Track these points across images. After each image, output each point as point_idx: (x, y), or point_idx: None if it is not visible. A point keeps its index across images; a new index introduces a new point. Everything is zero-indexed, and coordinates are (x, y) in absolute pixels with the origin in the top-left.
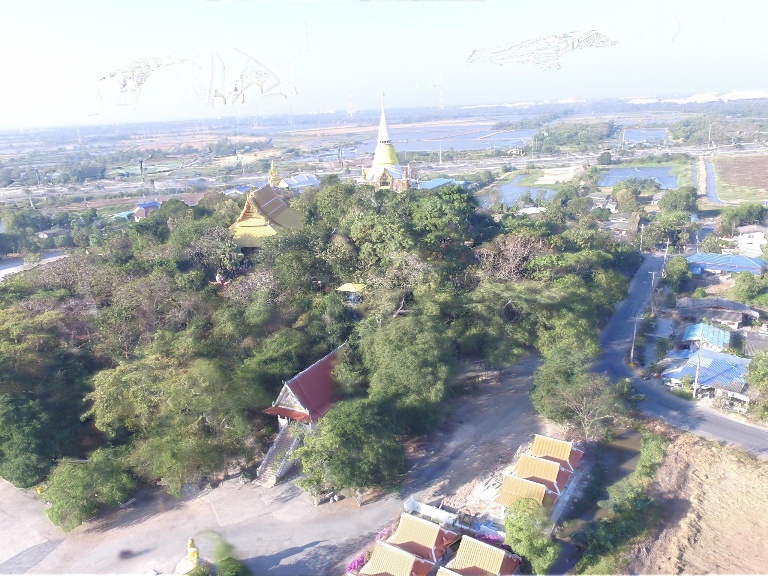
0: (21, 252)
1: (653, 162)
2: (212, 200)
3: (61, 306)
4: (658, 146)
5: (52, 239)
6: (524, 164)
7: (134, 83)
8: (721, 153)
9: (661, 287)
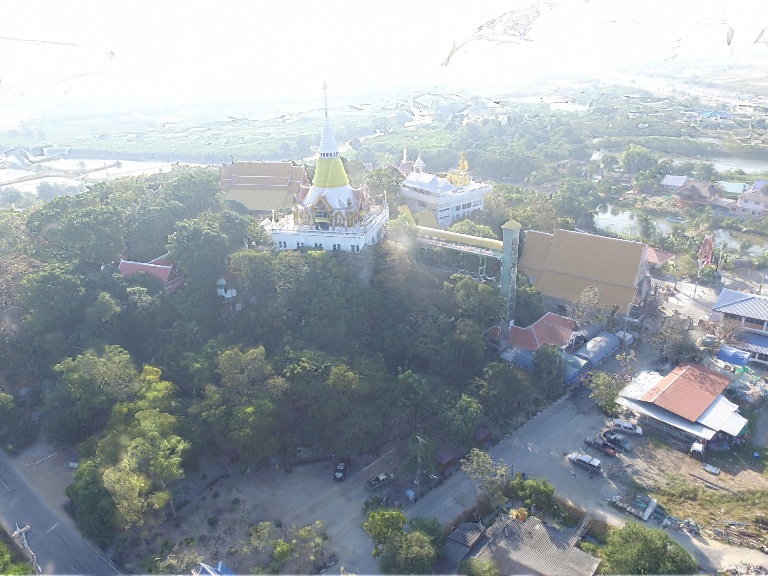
0: (552, 182)
1: None
2: None
3: None
4: None
5: (579, 180)
6: None
7: (516, 34)
8: None
9: (2, 542)
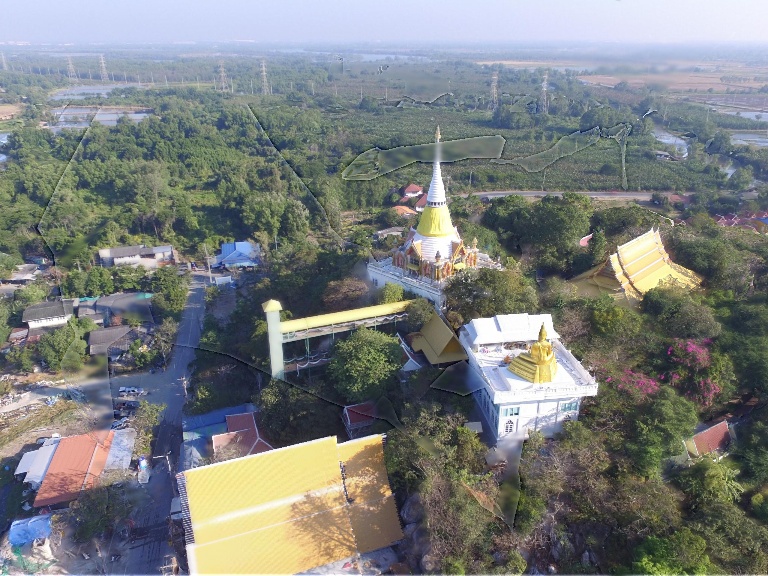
0: None
1: None
2: None
3: None
4: None
5: None
6: None
7: None
8: None
9: None
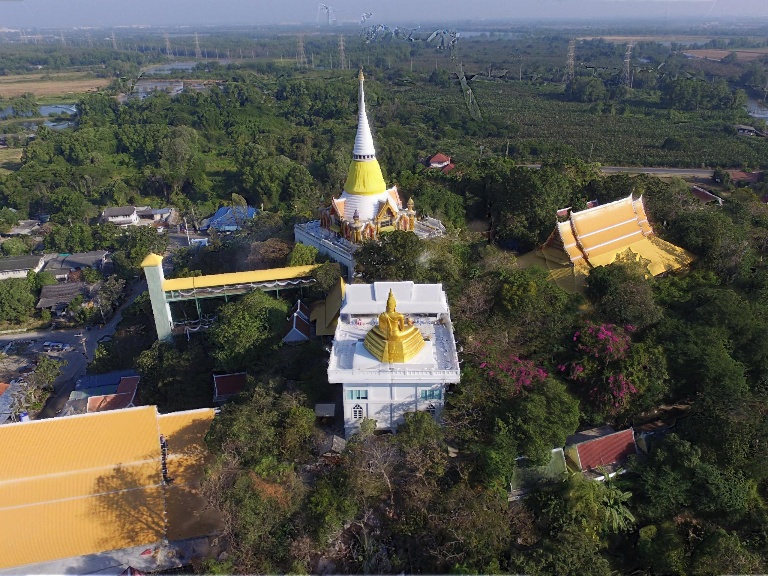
0: None
1: None
2: None
3: None
4: None
5: None
6: None
7: None
8: None
9: None
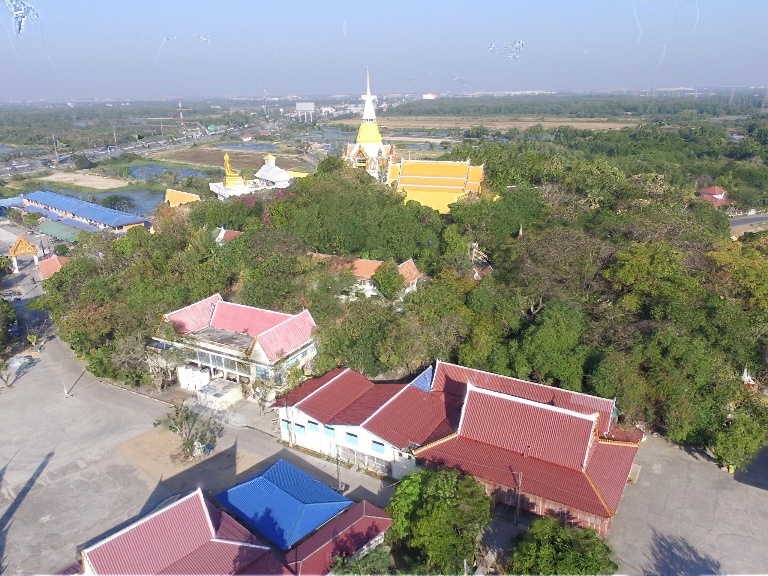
0: None
1: (123, 162)
2: (342, 191)
3: (693, 245)
4: (111, 148)
5: None
6: (8, 176)
7: None
8: (141, 152)
9: None
